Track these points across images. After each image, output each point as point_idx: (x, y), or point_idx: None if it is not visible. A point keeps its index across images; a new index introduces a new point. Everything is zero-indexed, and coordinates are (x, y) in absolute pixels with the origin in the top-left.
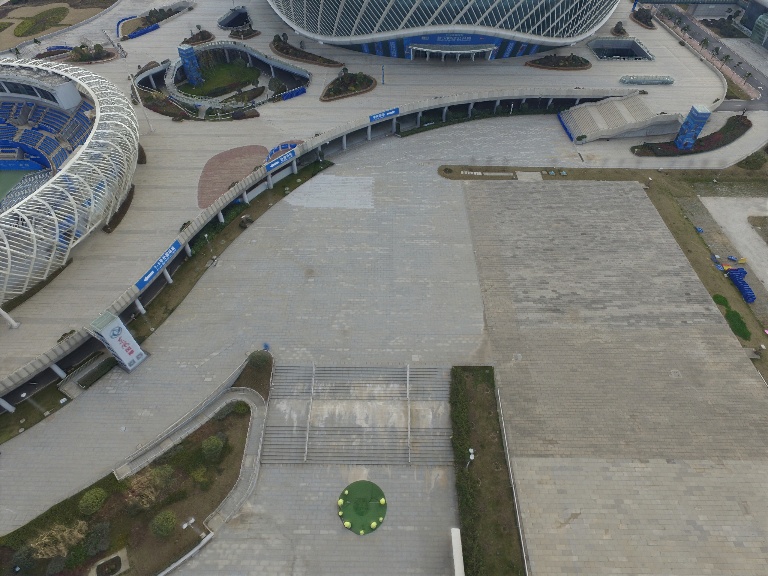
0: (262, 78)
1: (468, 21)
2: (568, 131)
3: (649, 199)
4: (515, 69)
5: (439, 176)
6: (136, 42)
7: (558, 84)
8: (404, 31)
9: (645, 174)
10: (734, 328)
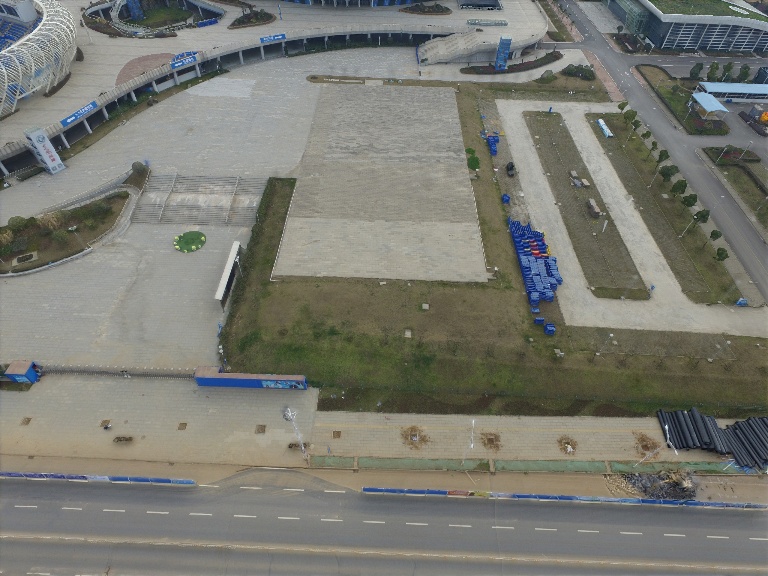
0: None
1: None
2: (417, 57)
3: (455, 98)
4: (390, 13)
5: (306, 81)
6: None
7: (418, 23)
8: None
9: (462, 84)
10: (469, 164)
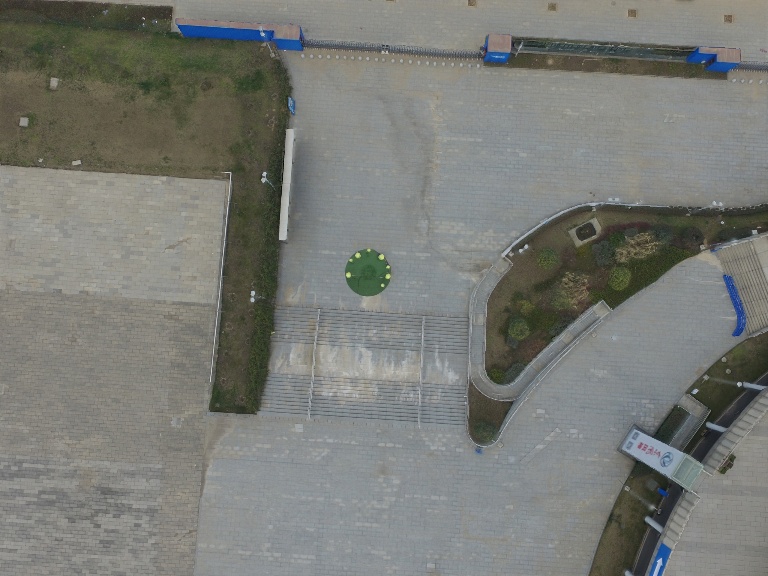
0: None
1: None
2: None
3: None
4: None
5: None
6: None
7: None
8: None
9: None
10: None
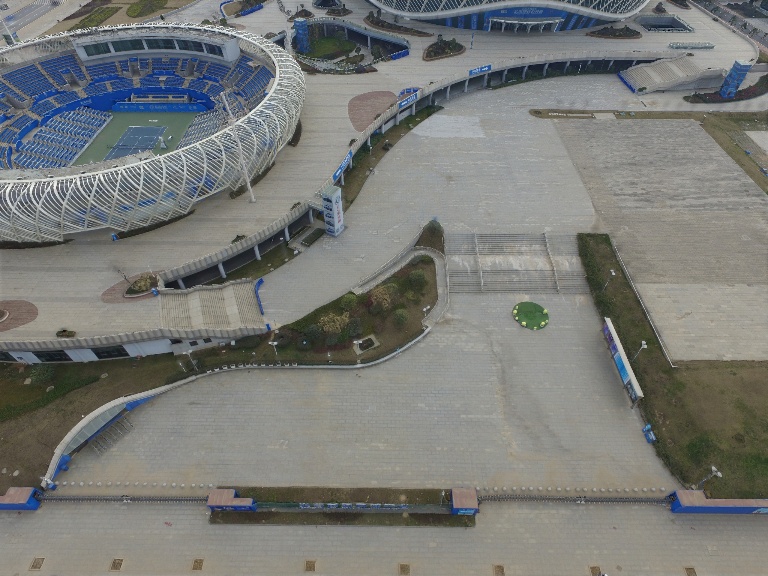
0: None
1: None
2: (629, 85)
3: (705, 131)
4: (578, 38)
5: (532, 116)
6: (248, 18)
7: (617, 49)
8: (487, 5)
9: (698, 115)
10: None
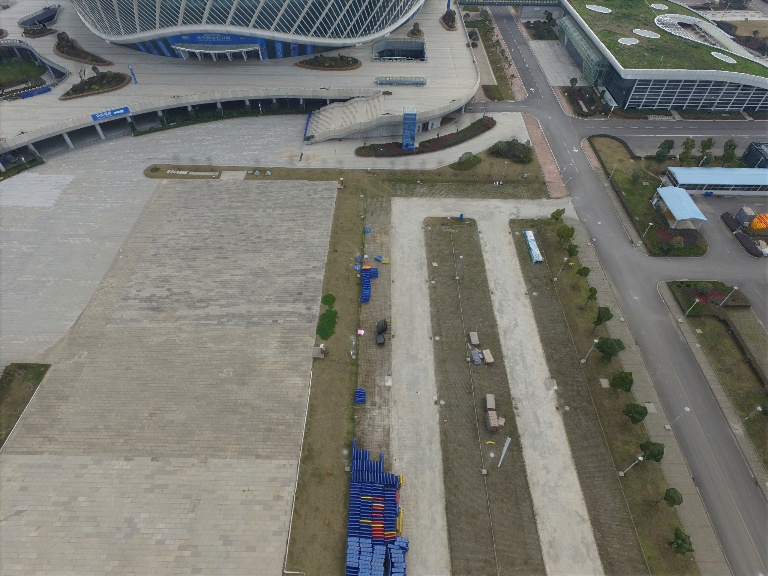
0: (44, 77)
1: (218, 21)
2: None
3: (334, 199)
4: (280, 69)
5: (142, 175)
6: None
7: (311, 84)
8: (161, 30)
9: (352, 174)
10: (319, 327)
